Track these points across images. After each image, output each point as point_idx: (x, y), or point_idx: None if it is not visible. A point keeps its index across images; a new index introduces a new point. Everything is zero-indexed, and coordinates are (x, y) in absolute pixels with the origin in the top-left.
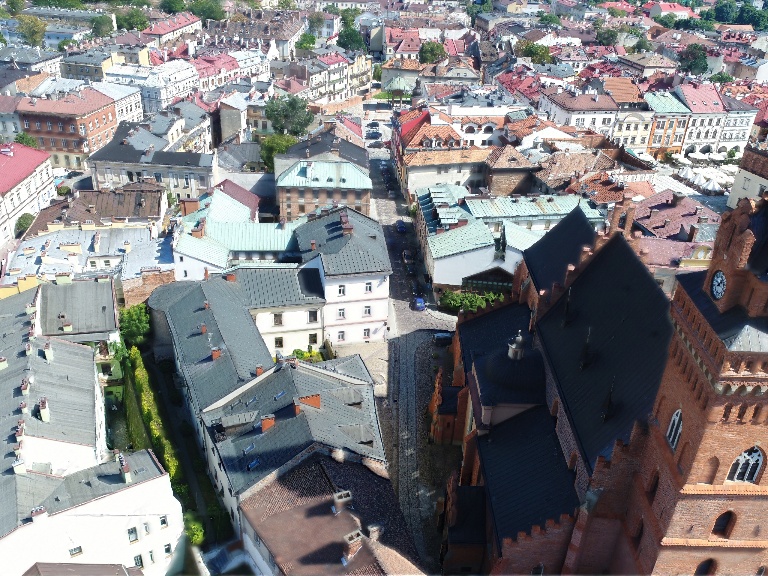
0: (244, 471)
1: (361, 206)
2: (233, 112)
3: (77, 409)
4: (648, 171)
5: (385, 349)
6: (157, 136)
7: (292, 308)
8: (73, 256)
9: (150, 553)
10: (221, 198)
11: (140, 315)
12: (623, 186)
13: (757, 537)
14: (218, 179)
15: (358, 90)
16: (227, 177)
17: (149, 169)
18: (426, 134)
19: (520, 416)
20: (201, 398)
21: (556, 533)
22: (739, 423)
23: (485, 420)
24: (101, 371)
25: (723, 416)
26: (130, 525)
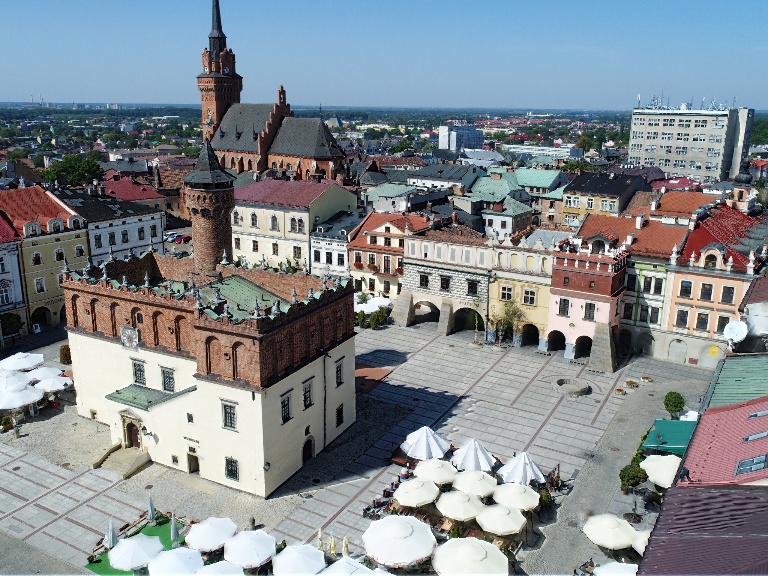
0: None
1: None
2: None
3: None
4: None
5: None
6: None
7: None
8: None
9: None
10: None
11: None
12: None
13: None
14: None
15: None
16: None
17: None
18: None
19: None
20: None
21: None
22: None
23: None
24: None
25: None
26: None
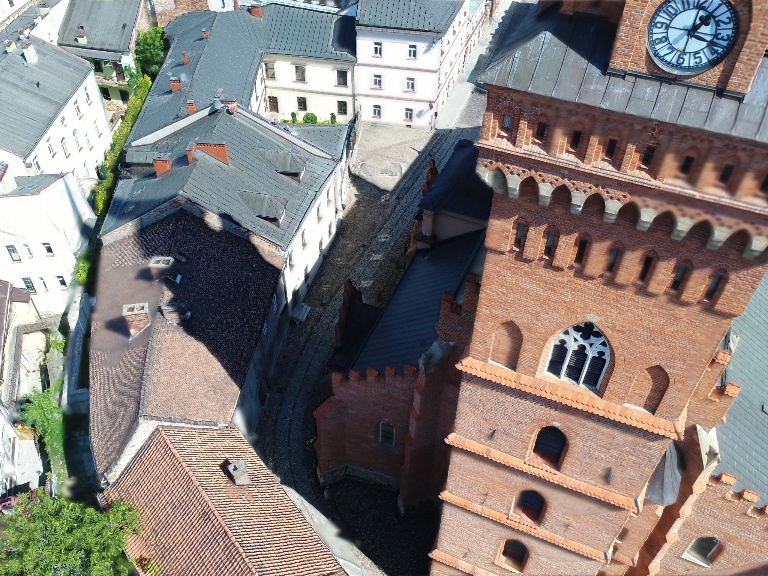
0: (120, 214)
1: None
2: None
3: (29, 117)
4: None
5: (426, 139)
6: None
7: (316, 62)
8: None
9: (42, 280)
10: None
11: (155, 40)
12: None
13: (610, 485)
14: None
15: None
16: None
17: None
18: None
19: (473, 235)
20: (138, 130)
21: (399, 387)
22: (549, 266)
23: (425, 229)
24: (120, 98)
25: (516, 243)
26: (6, 241)
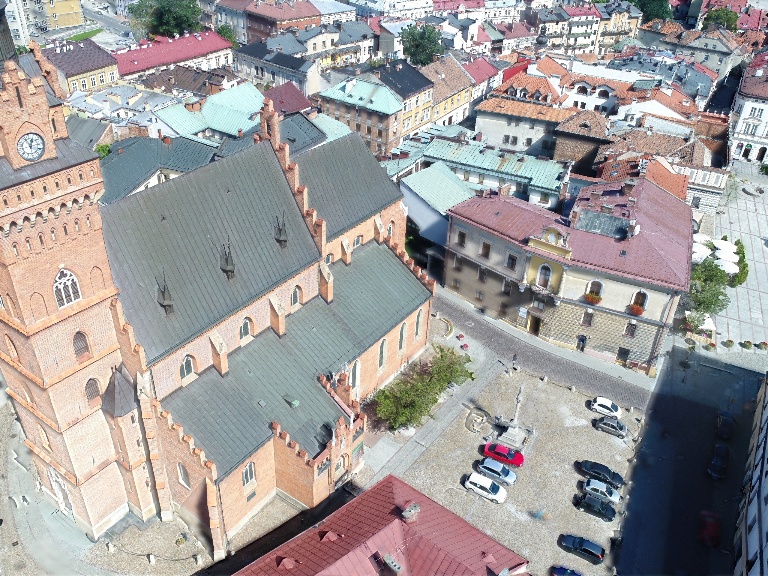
0: None
1: (382, 130)
2: (389, 36)
3: None
4: (714, 169)
5: None
6: (300, 43)
7: None
8: (105, 102)
9: None
10: (246, 89)
11: None
12: (640, 171)
13: None
14: (319, 87)
15: (611, 50)
16: (325, 86)
17: (268, 66)
18: (517, 83)
19: None
20: None
21: None
22: None
23: None
24: None
25: None
26: None
